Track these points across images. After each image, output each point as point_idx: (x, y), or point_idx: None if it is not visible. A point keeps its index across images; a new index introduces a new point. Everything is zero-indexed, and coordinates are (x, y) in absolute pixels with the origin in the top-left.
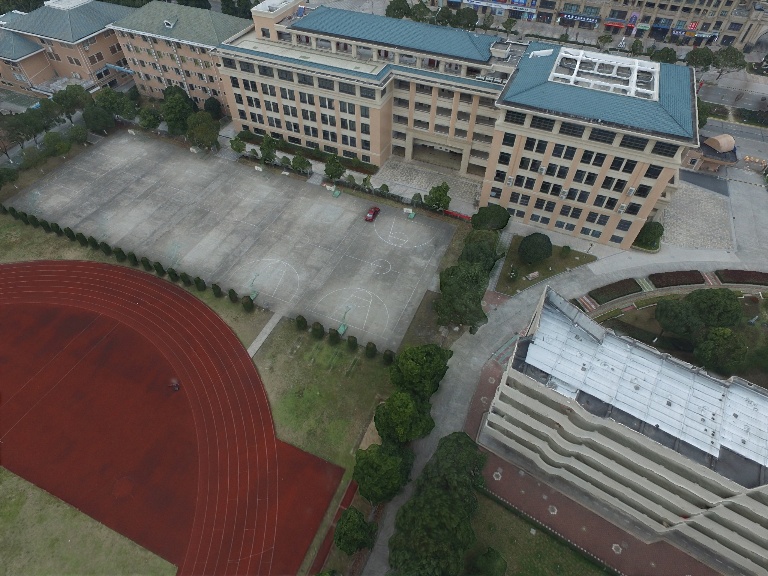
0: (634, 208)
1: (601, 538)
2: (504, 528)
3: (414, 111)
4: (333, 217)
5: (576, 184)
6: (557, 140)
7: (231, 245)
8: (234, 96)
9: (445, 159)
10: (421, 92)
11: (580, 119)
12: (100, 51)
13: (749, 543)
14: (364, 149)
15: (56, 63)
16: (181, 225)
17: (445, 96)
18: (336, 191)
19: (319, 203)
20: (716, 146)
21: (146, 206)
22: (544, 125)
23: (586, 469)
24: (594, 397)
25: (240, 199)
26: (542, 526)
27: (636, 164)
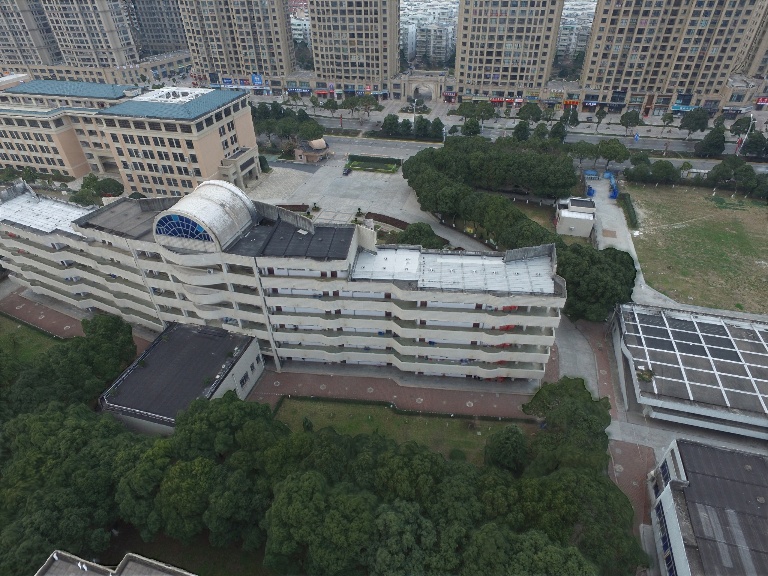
0: (198, 172)
1: (61, 325)
2: (1, 327)
3: (89, 136)
4: None
5: (163, 161)
6: (136, 133)
7: None
8: None
9: None
10: (87, 123)
11: (137, 117)
12: None
13: (100, 291)
14: (62, 166)
15: None
16: None
17: (101, 123)
18: None
19: None
20: (312, 146)
21: None
22: (126, 125)
23: (36, 276)
24: (9, 220)
25: None
26: (26, 323)
27: (179, 141)
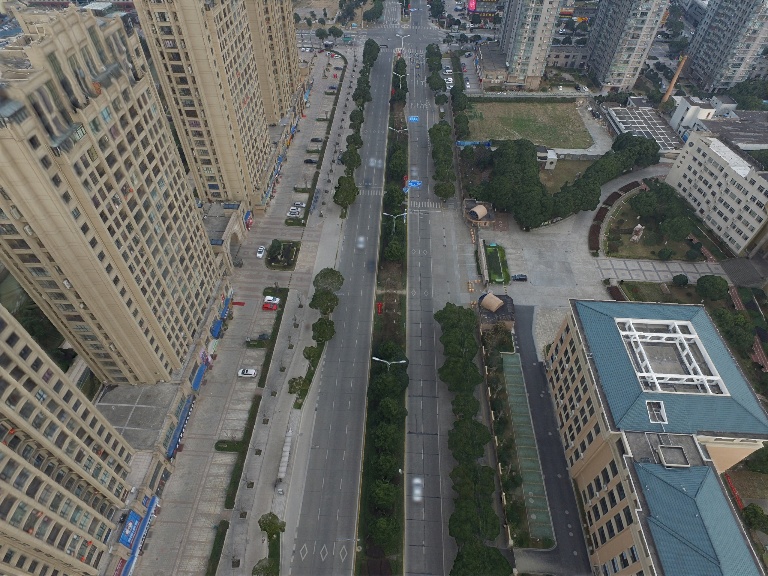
0: None
1: None
2: None
3: None
4: None
5: None
6: None
7: None
8: None
9: None
10: None
11: None
12: None
13: None
14: None
15: None
16: None
17: None
18: None
19: None
20: None
21: None
22: None
23: None
24: None
25: None
26: None
27: None
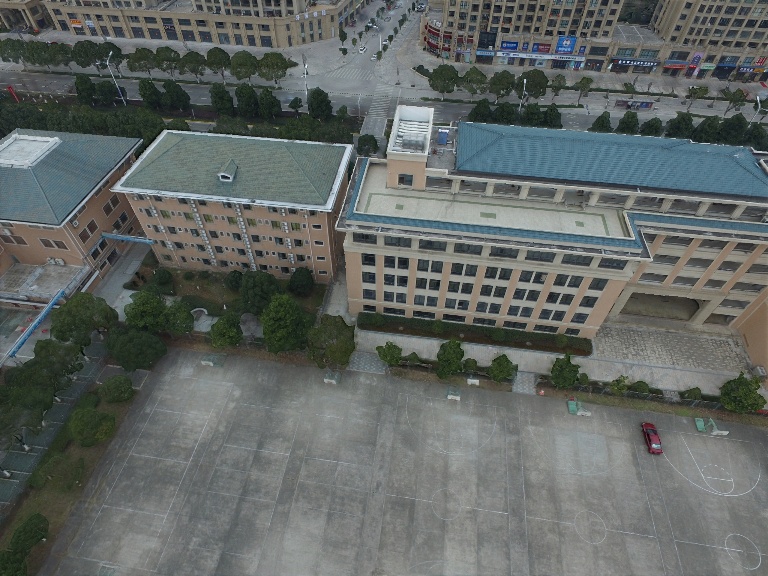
0: None
1: None
2: None
3: (648, 264)
4: (601, 459)
5: None
6: None
7: (497, 574)
8: (361, 275)
9: (657, 304)
10: (670, 243)
11: None
12: (92, 218)
13: None
14: (574, 322)
15: (16, 247)
16: (388, 549)
17: (709, 245)
18: (570, 403)
19: (562, 433)
20: None
21: (304, 518)
22: None
23: None
24: None
25: (444, 457)
26: None
27: None
